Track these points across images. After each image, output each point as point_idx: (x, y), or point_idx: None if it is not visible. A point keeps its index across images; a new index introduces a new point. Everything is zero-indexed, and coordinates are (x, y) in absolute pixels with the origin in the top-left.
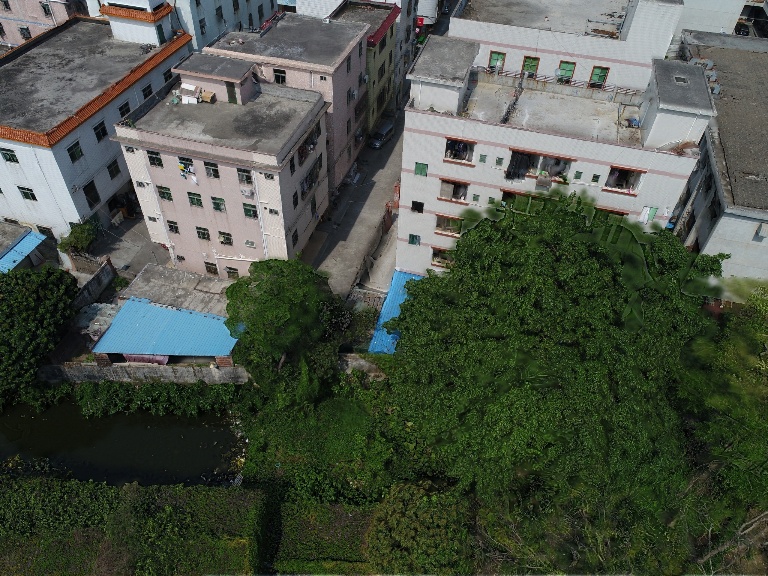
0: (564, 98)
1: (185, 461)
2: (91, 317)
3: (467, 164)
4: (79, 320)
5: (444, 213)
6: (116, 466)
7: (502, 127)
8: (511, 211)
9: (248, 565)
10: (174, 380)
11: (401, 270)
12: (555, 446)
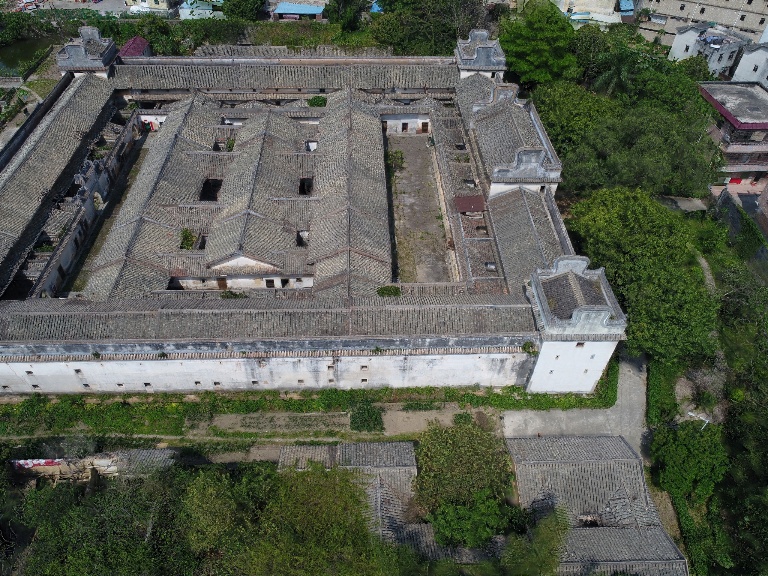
0: None
1: None
2: (268, 8)
3: None
4: (264, 9)
5: None
6: None
7: None
8: None
9: (340, 29)
10: None
11: None
12: None
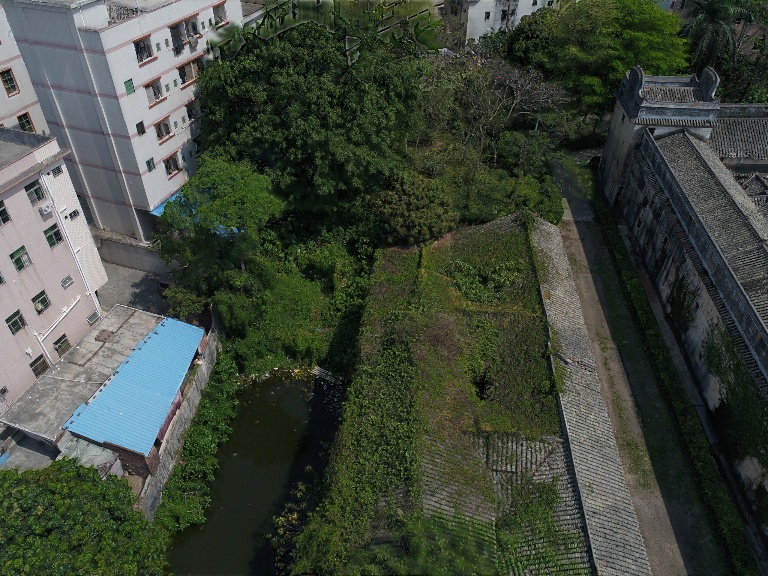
0: (114, 2)
1: (288, 415)
2: None
3: (153, 59)
4: None
5: (157, 119)
6: (280, 477)
7: (158, 10)
8: (249, 33)
9: None
10: (191, 417)
11: (154, 207)
12: (396, 106)
